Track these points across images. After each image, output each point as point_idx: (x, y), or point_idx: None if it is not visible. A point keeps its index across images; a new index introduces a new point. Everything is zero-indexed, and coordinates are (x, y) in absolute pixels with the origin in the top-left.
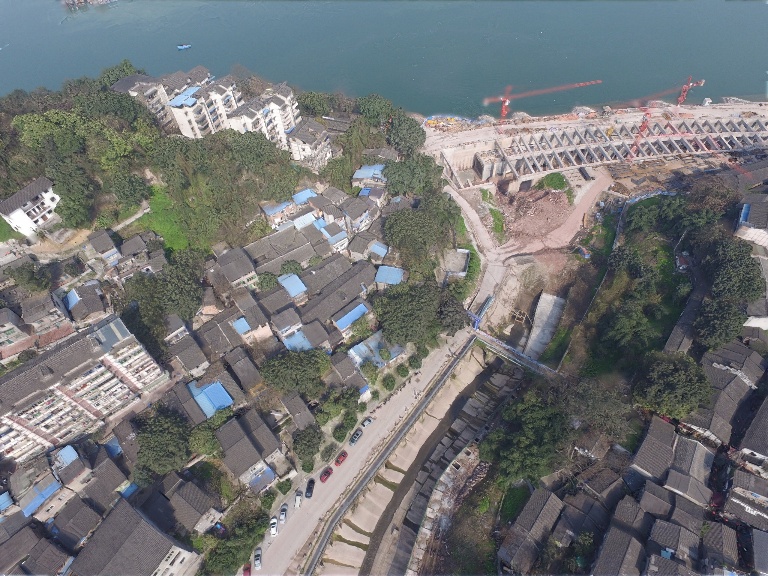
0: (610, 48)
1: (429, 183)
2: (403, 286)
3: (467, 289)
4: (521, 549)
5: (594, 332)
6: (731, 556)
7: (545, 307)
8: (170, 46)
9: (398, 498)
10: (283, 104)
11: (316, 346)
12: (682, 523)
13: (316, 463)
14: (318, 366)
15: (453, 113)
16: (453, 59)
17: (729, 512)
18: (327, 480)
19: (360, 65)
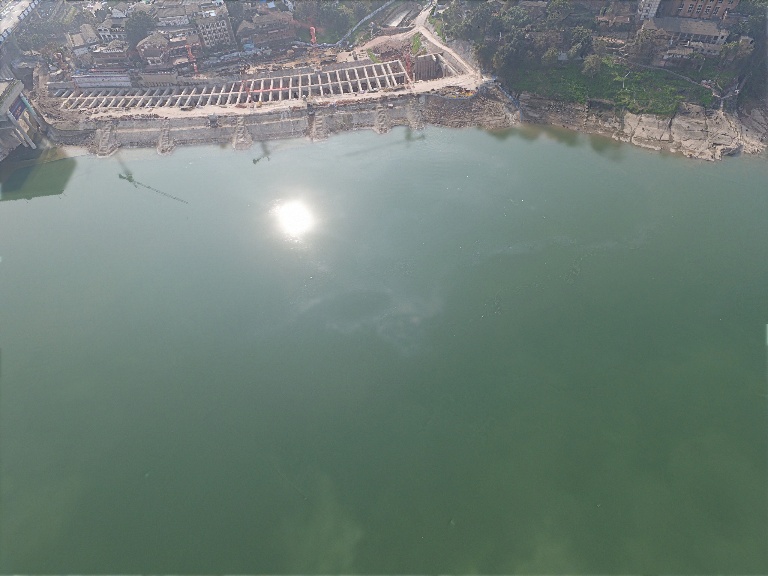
0: (224, 240)
1: None
2: None
3: None
4: None
5: None
6: None
7: (396, 22)
8: None
9: None
10: None
11: None
12: None
13: None
14: None
15: (451, 135)
16: (460, 214)
17: None
18: None
19: (595, 200)
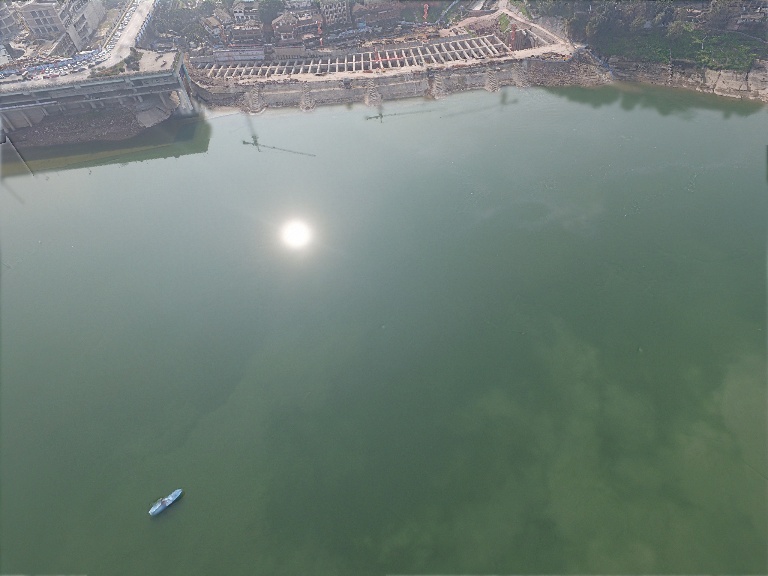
0: (386, 170)
1: None
2: None
3: None
4: None
5: None
6: None
7: (478, 7)
8: None
9: None
10: None
11: None
12: None
13: None
14: None
15: (554, 92)
16: (582, 147)
17: None
18: None
19: (695, 135)
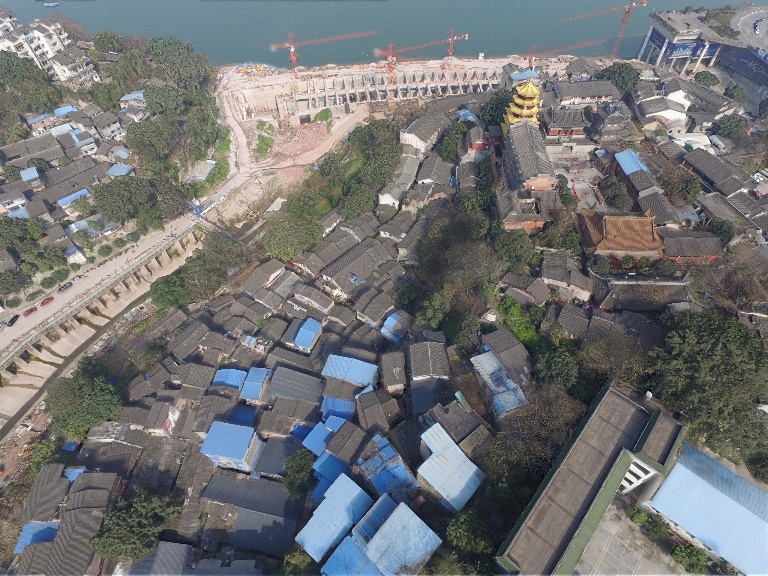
0: None
1: (202, 111)
2: (124, 176)
3: (204, 190)
4: (141, 344)
5: (278, 214)
6: (273, 336)
7: (275, 207)
8: (36, 3)
9: (98, 335)
10: (47, 32)
11: (34, 216)
12: (249, 318)
13: (22, 303)
14: (26, 228)
15: (274, 64)
16: (293, 20)
17: (285, 310)
18: (29, 315)
19: (208, 23)
